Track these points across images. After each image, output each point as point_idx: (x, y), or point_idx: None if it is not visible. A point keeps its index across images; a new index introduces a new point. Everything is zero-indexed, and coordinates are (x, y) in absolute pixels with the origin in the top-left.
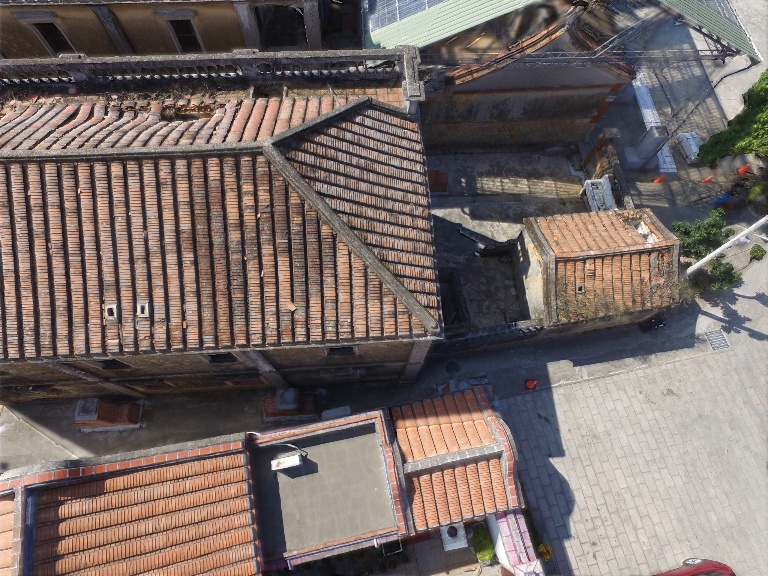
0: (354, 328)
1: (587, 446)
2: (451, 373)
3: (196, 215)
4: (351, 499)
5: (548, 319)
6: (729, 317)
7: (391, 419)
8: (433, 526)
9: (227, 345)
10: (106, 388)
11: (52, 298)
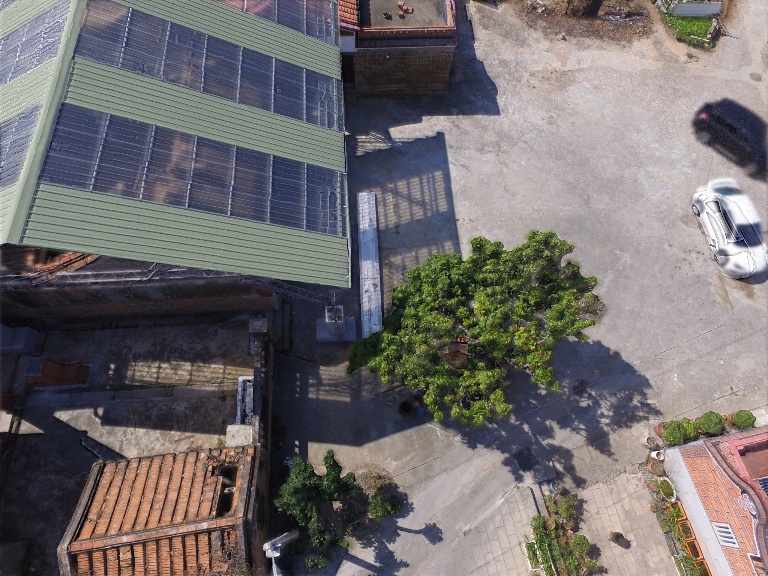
0: None
1: None
2: None
3: None
4: None
5: None
6: (381, 562)
7: None
8: None
9: None
10: None
11: None
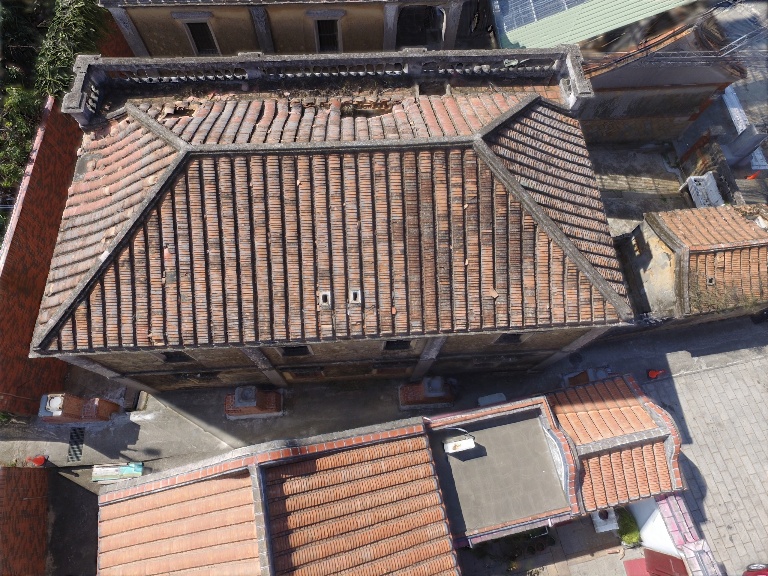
0: (552, 314)
1: (713, 434)
2: (575, 363)
3: (407, 206)
4: (522, 481)
5: (680, 310)
6: None
7: (549, 405)
8: (602, 507)
9: (433, 330)
10: (260, 376)
11: (270, 285)
